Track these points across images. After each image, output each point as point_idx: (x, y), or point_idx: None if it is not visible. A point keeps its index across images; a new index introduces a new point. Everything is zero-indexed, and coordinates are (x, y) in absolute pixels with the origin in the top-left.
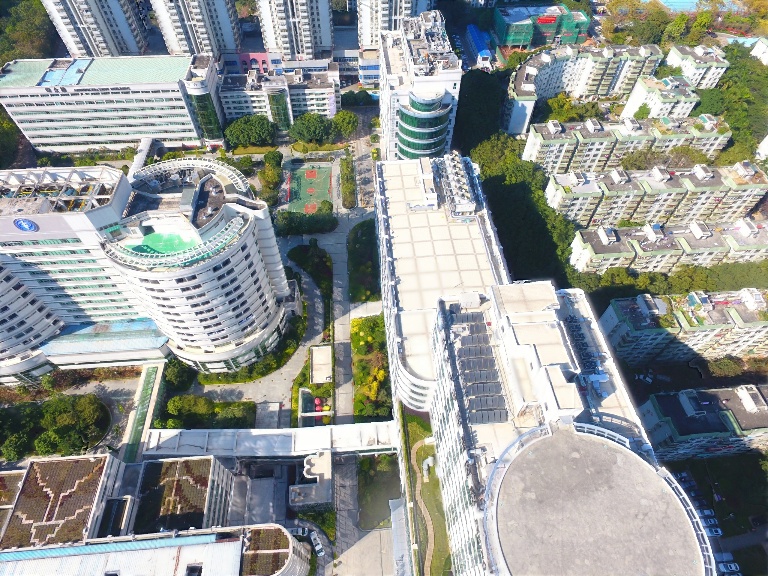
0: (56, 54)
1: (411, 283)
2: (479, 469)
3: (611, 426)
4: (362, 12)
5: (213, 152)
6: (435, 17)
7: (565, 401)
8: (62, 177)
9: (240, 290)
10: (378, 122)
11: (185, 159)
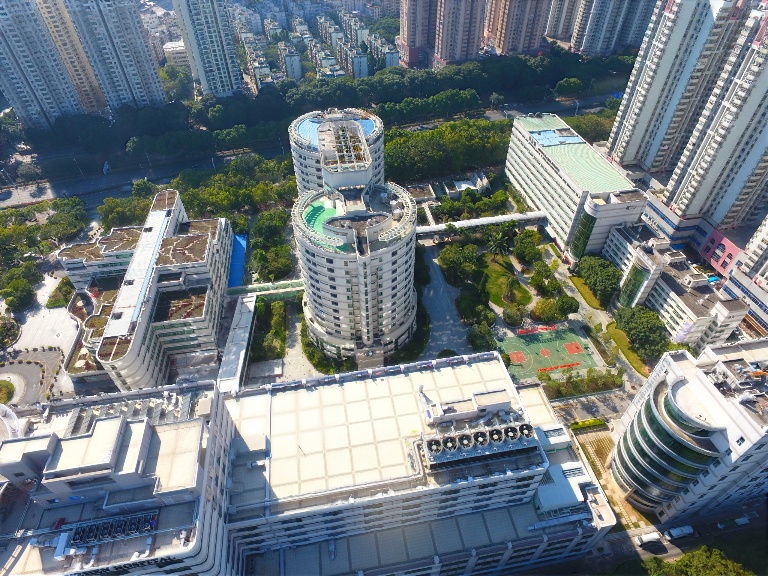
0: None
1: (307, 401)
2: (33, 417)
3: (7, 554)
4: None
5: (564, 262)
6: None
7: (8, 450)
8: None
9: (318, 285)
10: None
11: None
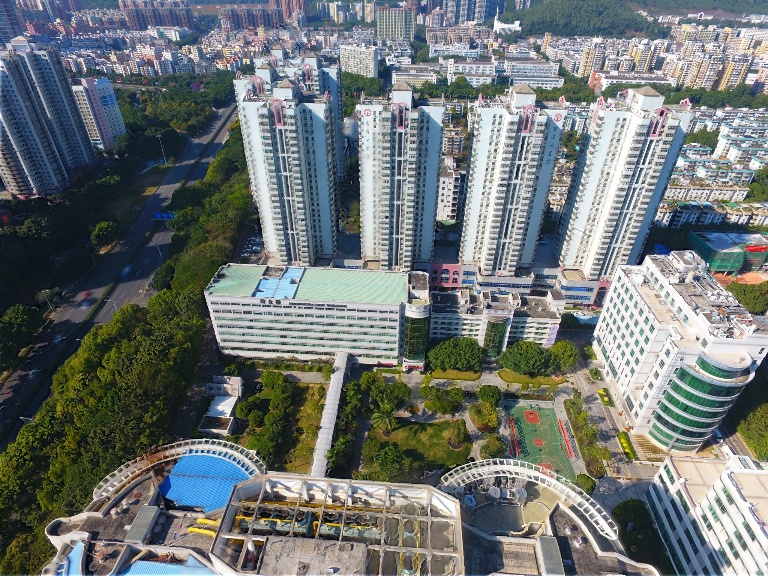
0: (238, 242)
1: None
2: None
3: None
4: (573, 236)
5: (408, 372)
6: (692, 258)
7: None
8: (364, 490)
9: None
10: (593, 352)
11: (501, 461)
